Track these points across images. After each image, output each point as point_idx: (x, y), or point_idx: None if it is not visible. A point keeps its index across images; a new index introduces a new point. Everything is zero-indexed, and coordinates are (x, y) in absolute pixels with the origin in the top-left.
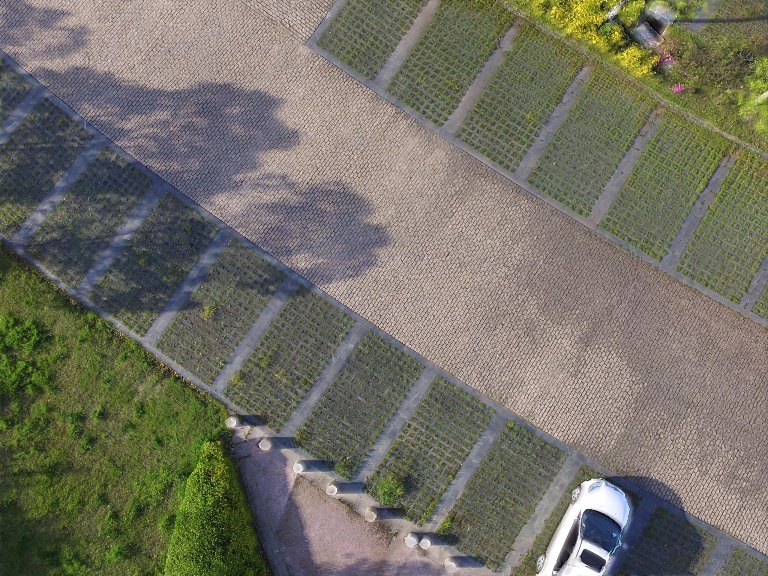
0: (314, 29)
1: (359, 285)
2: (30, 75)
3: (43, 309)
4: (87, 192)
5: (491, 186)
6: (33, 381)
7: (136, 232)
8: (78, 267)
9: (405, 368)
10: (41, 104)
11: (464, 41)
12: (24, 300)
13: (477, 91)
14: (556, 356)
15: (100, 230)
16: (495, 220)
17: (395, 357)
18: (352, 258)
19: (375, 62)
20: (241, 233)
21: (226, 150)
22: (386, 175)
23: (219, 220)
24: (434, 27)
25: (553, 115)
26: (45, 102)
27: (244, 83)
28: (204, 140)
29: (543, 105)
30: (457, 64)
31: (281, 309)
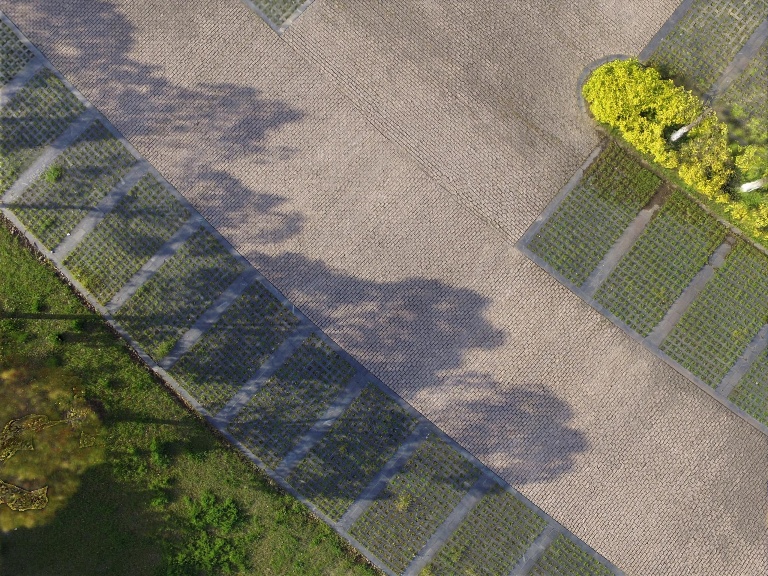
0: (524, 232)
1: (553, 488)
2: (242, 256)
3: (243, 488)
4: (291, 375)
5: (692, 401)
6: (230, 559)
7: (337, 419)
8: (278, 448)
9: (595, 575)
10: (252, 286)
11: (673, 255)
12: (225, 478)
13: (683, 305)
14: (747, 575)
15: (302, 414)
16: (693, 434)
17: (586, 563)
18: (548, 460)
19: (583, 269)
20: (440, 427)
21: (430, 345)
22: (586, 381)
23: (419, 413)
24: (643, 238)
25: (758, 335)
26: (255, 284)
27: (451, 279)
28: (408, 333)
29: (749, 324)
30: (664, 276)
31: (475, 506)
